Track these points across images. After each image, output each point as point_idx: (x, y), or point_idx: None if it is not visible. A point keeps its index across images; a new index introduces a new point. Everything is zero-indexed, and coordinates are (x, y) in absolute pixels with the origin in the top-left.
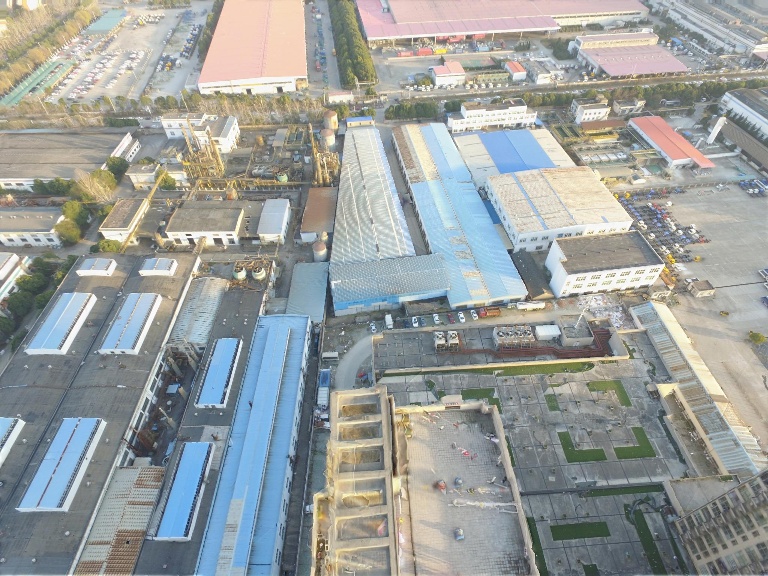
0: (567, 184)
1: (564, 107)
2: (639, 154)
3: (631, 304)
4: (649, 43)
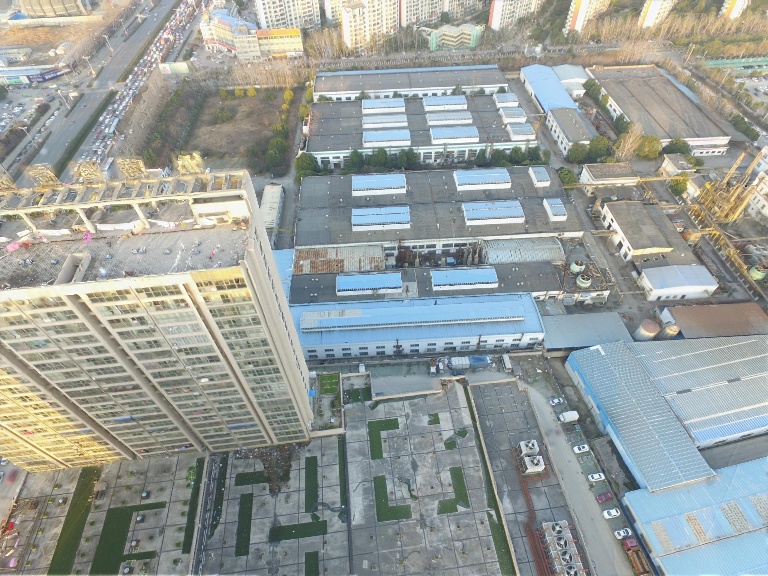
0: None
1: None
2: None
3: None
4: None
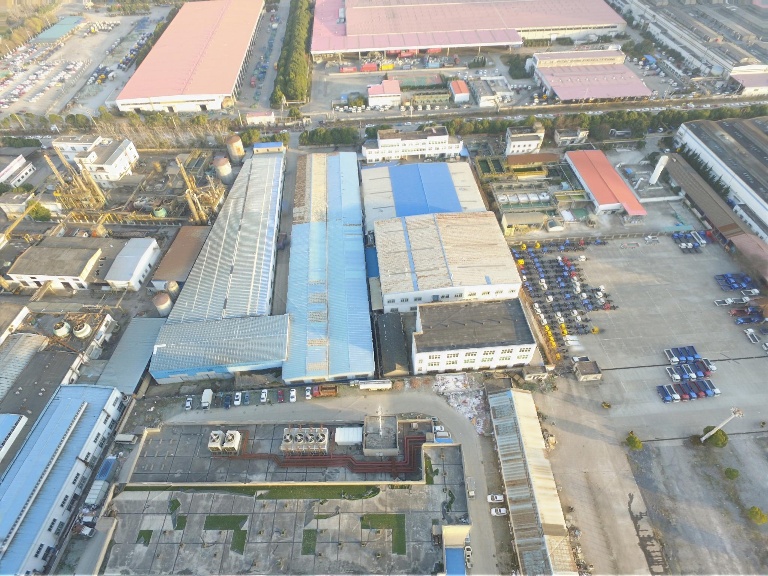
0: (459, 234)
1: (498, 136)
2: (563, 196)
3: (492, 390)
4: (615, 62)
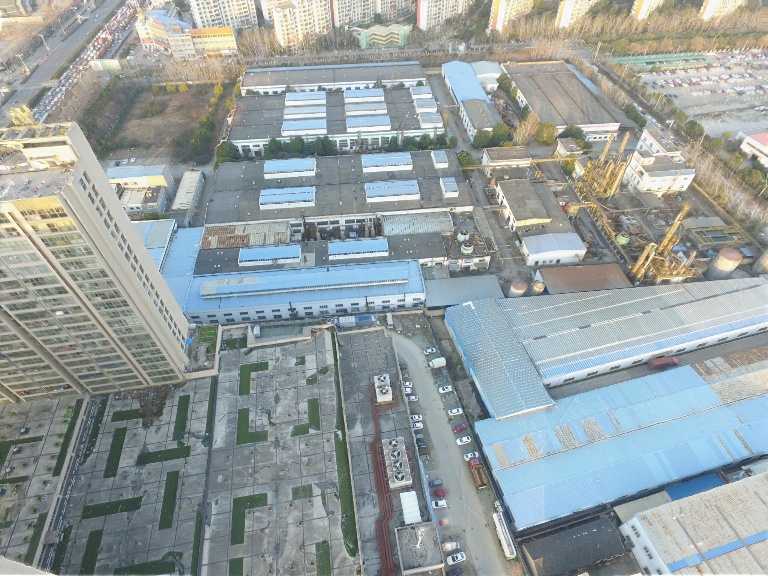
0: None
1: None
2: None
3: None
4: None
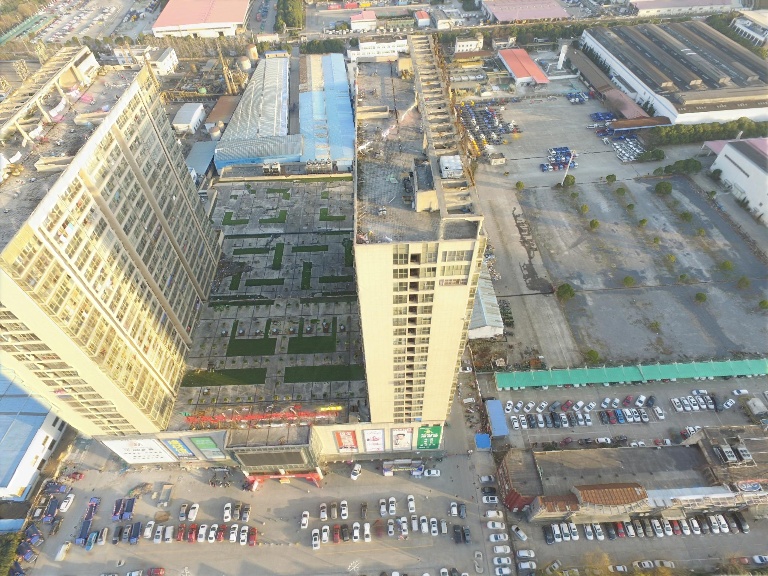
0: None
1: None
2: (493, 75)
3: None
4: None
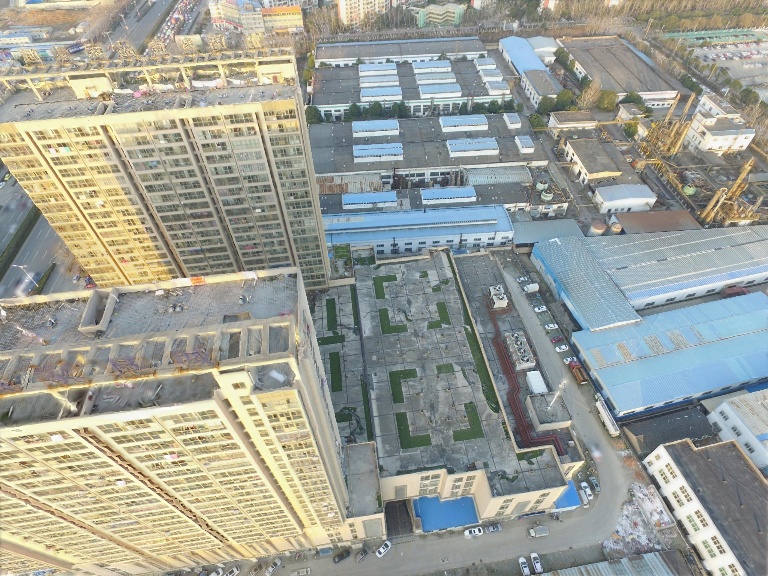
0: None
1: None
2: None
3: None
4: None
